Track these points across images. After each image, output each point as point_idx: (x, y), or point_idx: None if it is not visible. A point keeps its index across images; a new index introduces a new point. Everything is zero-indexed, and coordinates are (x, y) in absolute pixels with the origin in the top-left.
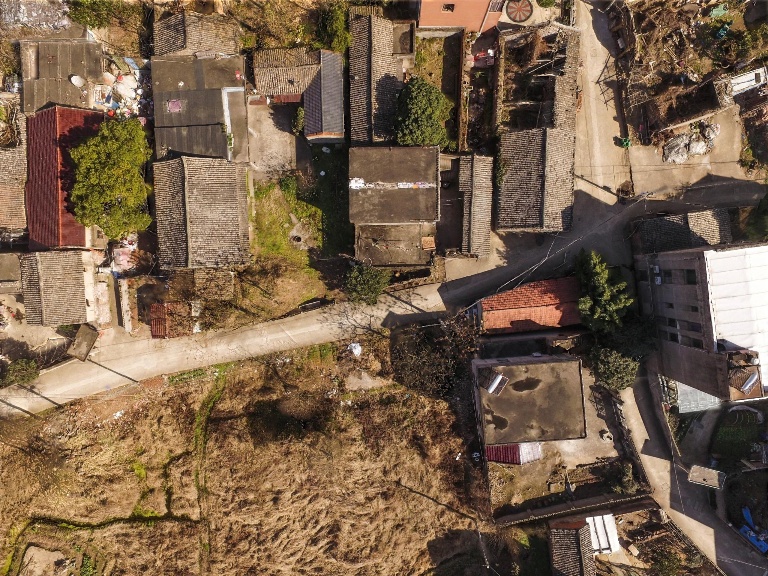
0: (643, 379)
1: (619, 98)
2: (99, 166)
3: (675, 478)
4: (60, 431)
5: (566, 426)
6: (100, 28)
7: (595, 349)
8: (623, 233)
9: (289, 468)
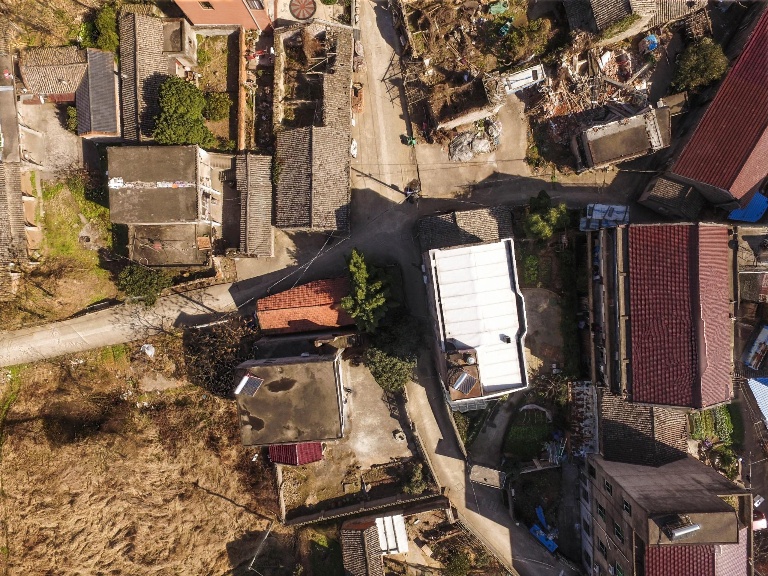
0: (434, 378)
1: (404, 96)
2: None
3: (468, 478)
4: None
5: (322, 427)
6: None
7: None
8: (412, 232)
9: (86, 470)
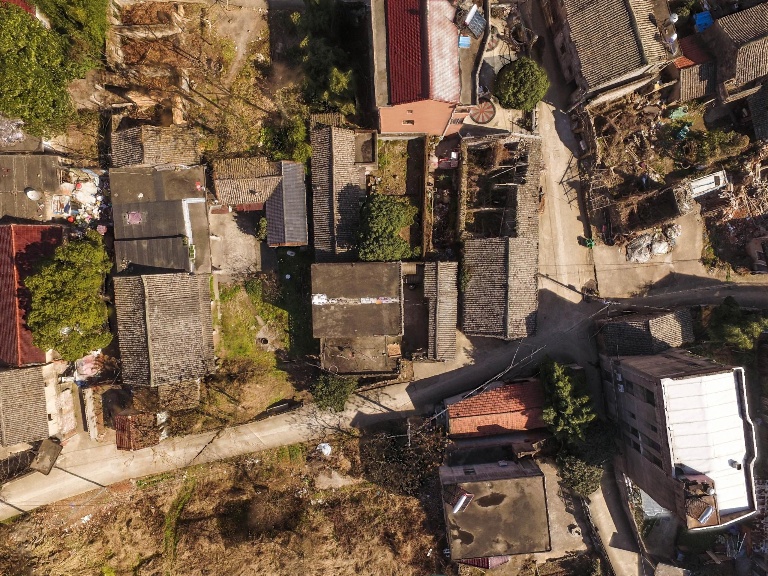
0: (610, 474)
1: (582, 198)
2: (54, 296)
3: (643, 570)
4: (26, 539)
5: (531, 540)
6: (57, 136)
7: (560, 454)
8: (588, 331)
9: (261, 567)
